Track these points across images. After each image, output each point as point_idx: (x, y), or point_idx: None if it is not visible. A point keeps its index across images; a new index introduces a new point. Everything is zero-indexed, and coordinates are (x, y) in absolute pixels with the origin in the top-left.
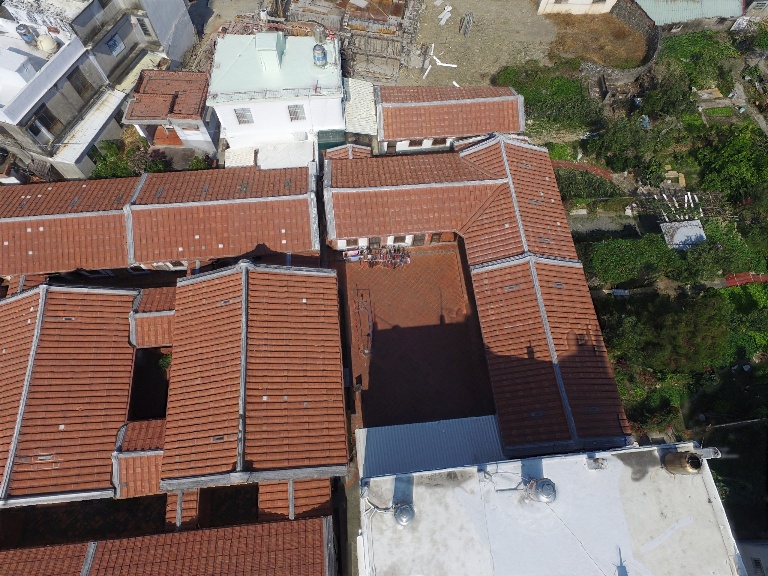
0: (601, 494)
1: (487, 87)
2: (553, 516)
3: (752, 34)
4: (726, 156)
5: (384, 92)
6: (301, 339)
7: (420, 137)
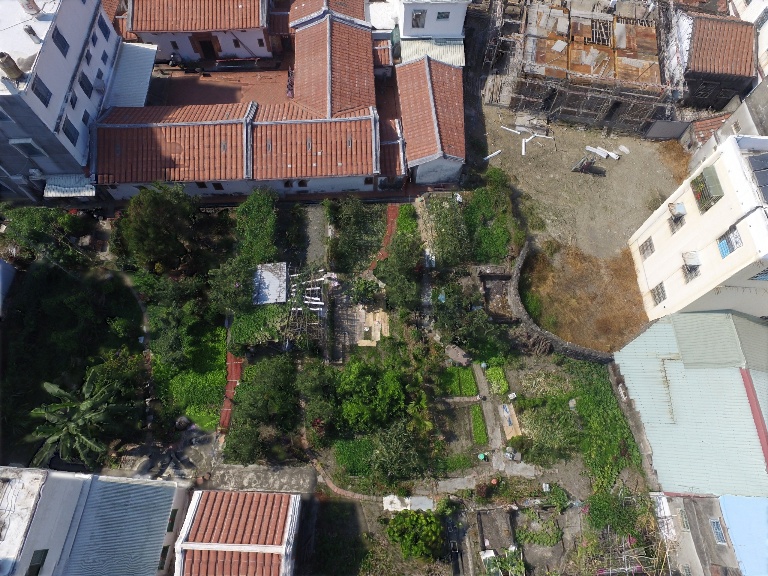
0: (20, 43)
1: (463, 141)
2: (20, 22)
3: (621, 495)
4: (385, 383)
5: (451, 69)
6: (213, 5)
7: (400, 91)
